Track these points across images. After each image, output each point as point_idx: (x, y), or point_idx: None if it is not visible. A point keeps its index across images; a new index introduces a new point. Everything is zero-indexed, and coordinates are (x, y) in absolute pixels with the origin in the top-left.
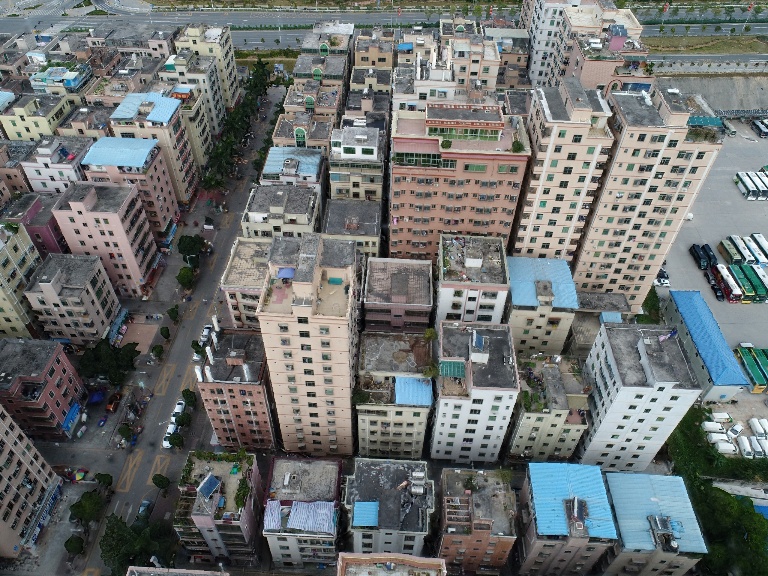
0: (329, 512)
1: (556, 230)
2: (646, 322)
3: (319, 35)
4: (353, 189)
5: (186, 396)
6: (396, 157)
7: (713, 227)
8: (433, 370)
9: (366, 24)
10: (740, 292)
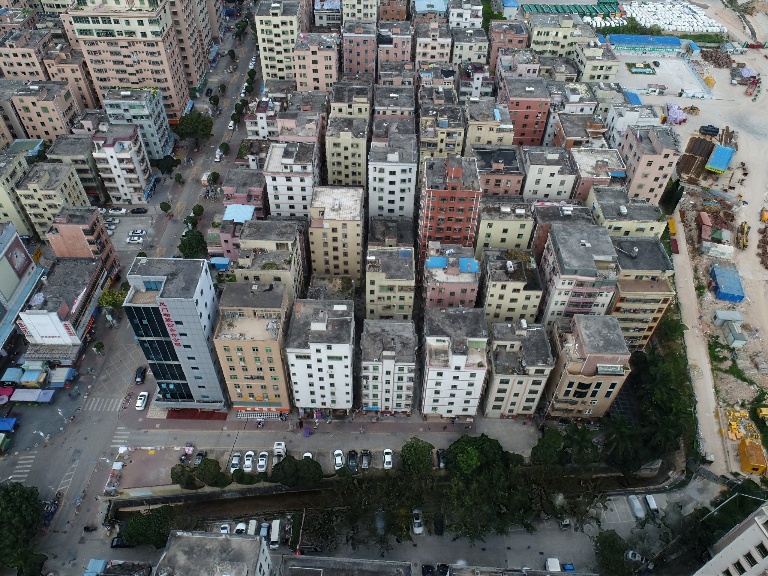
0: (338, 3)
1: None
2: (483, 1)
3: None
4: None
5: None
6: None
7: None
8: None
9: None
10: None
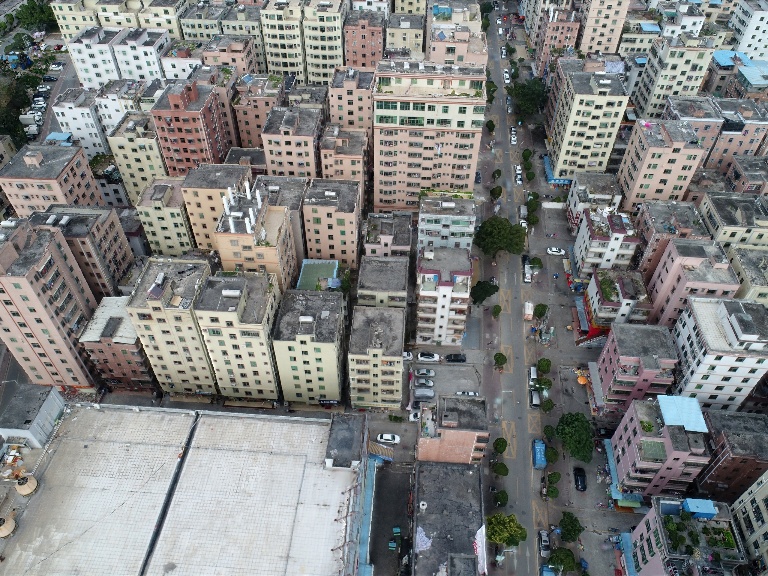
0: (622, 66)
1: None
2: None
3: None
4: None
5: (512, 62)
6: None
7: None
8: (660, 16)
9: None
10: None
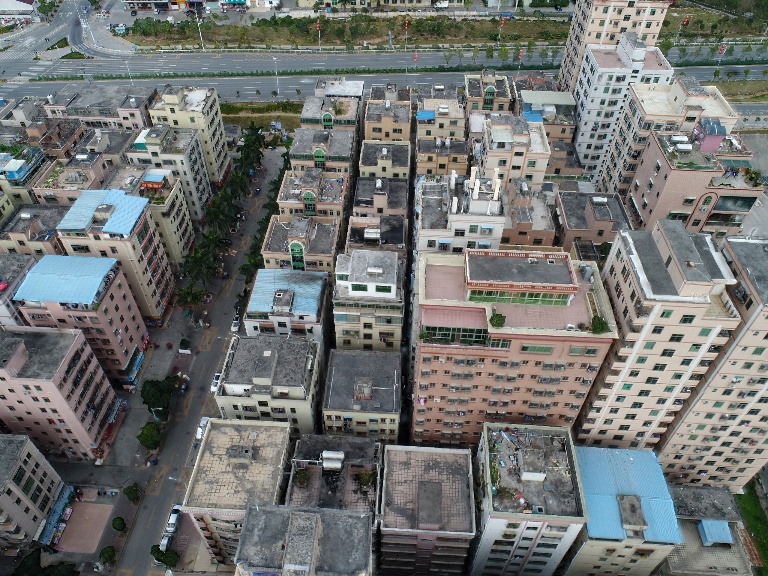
0: None
1: (641, 413)
2: None
3: (322, 99)
4: (364, 330)
5: None
6: (425, 331)
7: None
8: None
9: (376, 68)
10: None
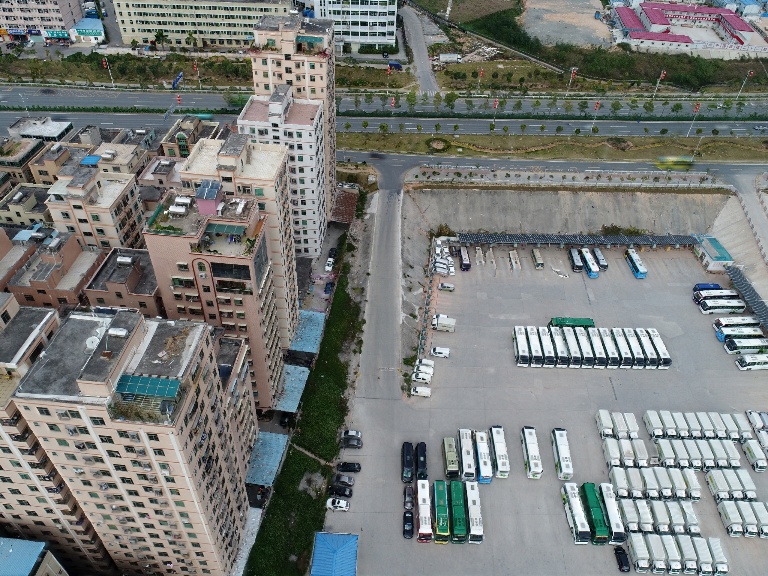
0: None
1: (29, 499)
2: None
3: None
4: None
5: None
6: None
7: (453, 409)
8: None
9: (161, 107)
10: (429, 530)
